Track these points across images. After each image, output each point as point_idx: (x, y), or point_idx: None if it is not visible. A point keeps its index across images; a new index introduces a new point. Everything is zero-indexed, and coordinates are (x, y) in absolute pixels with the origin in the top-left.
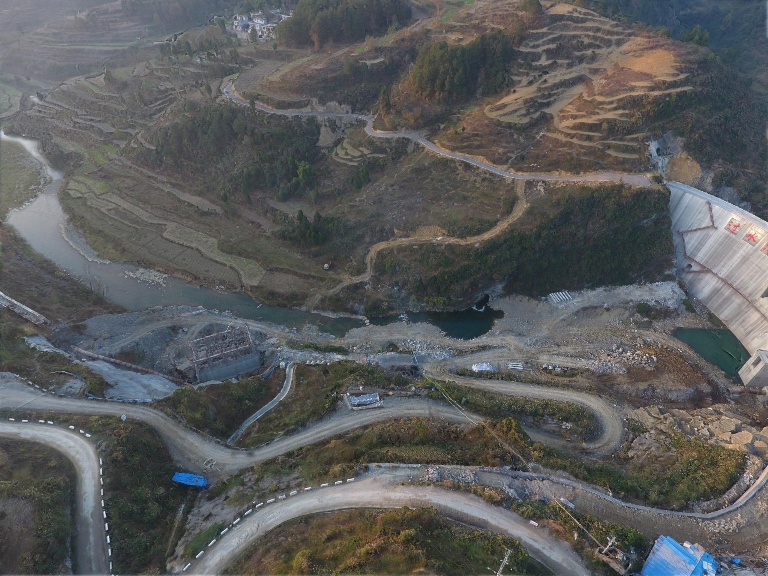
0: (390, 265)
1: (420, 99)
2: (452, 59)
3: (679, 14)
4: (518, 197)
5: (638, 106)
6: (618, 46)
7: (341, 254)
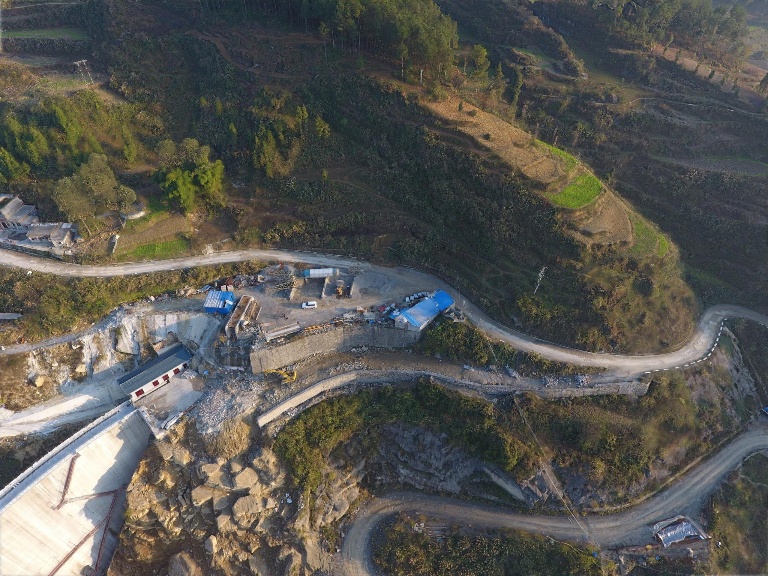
0: None
1: None
2: None
3: None
4: None
5: None
6: None
7: None
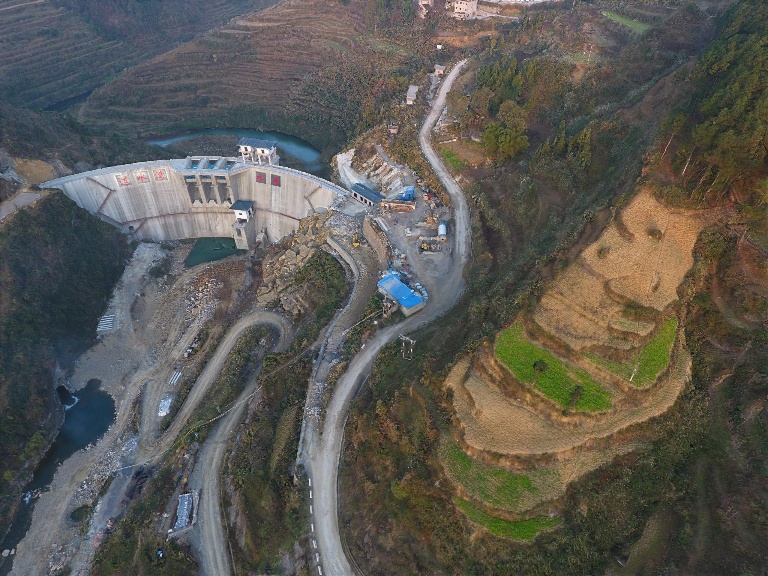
0: None
1: None
2: None
3: None
4: None
5: None
6: None
7: None
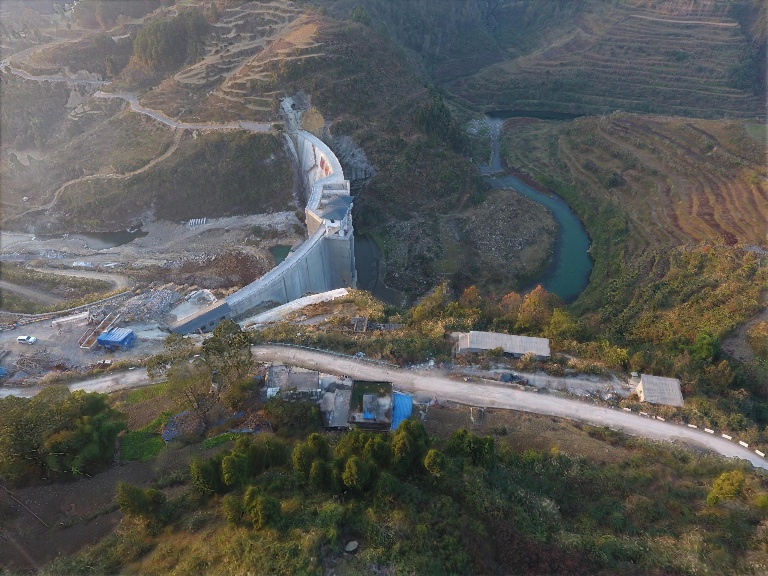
0: (67, 196)
1: (143, 67)
2: (157, 32)
3: (501, 7)
4: (174, 142)
5: (276, 69)
6: (290, 22)
7: (40, 189)
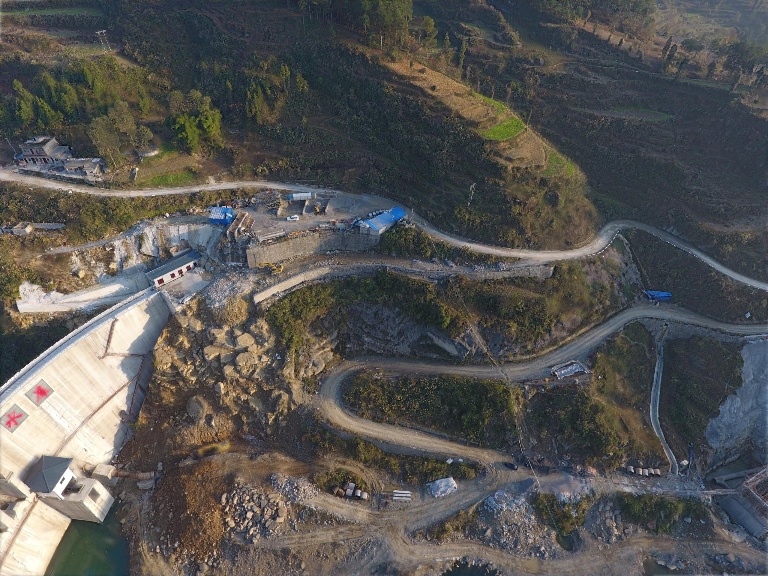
0: None
1: None
2: None
3: None
4: None
5: None
6: None
7: None
